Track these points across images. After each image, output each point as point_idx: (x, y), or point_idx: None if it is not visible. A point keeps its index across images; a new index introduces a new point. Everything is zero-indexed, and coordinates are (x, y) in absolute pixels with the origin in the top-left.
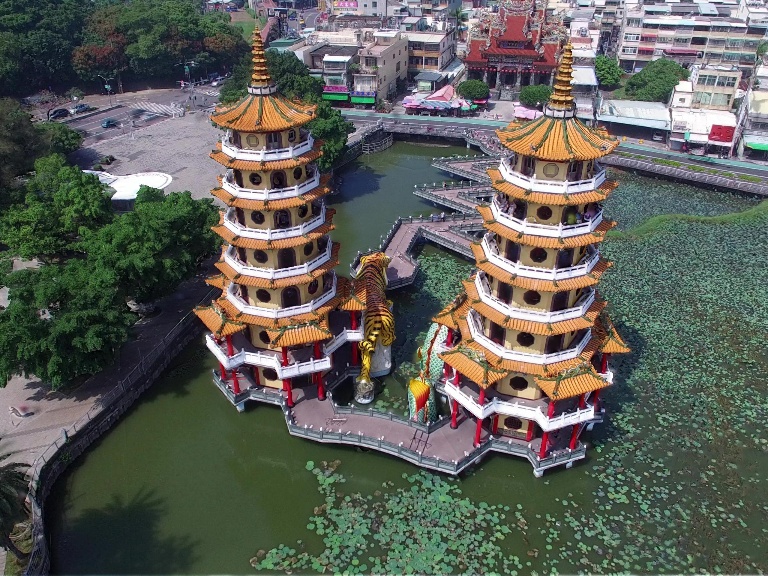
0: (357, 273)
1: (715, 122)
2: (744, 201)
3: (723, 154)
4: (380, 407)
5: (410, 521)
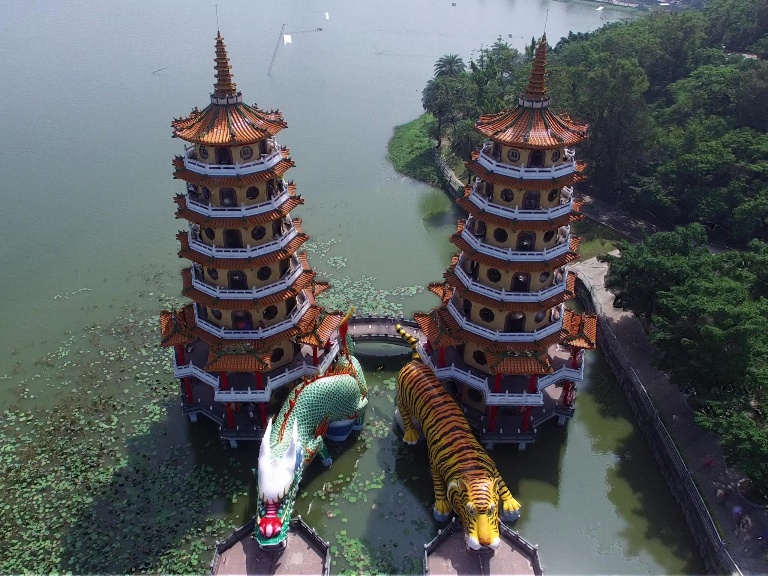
0: None
1: None
2: None
3: None
4: (391, 383)
5: None
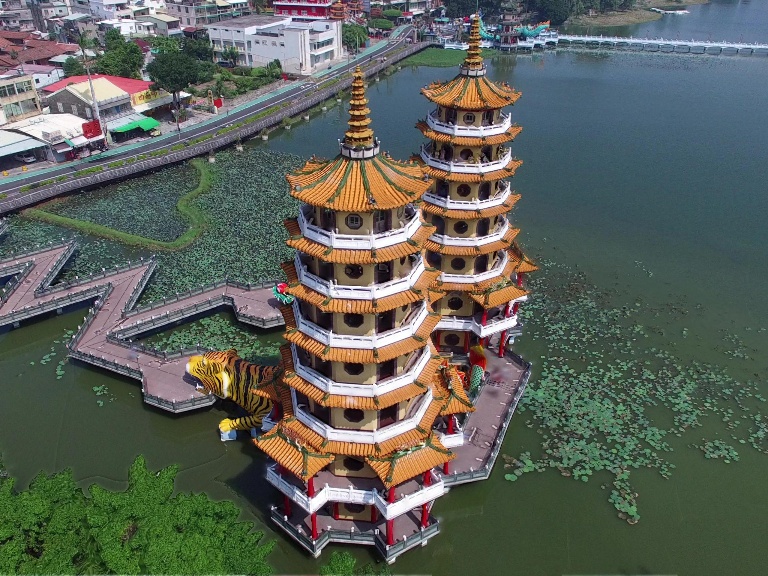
0: (226, 385)
1: (68, 124)
2: (183, 169)
3: (102, 147)
4: None
5: (568, 415)
